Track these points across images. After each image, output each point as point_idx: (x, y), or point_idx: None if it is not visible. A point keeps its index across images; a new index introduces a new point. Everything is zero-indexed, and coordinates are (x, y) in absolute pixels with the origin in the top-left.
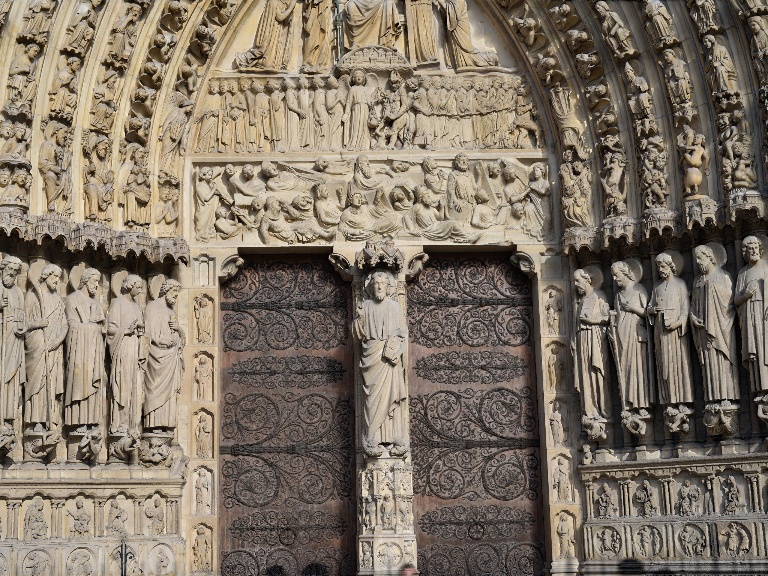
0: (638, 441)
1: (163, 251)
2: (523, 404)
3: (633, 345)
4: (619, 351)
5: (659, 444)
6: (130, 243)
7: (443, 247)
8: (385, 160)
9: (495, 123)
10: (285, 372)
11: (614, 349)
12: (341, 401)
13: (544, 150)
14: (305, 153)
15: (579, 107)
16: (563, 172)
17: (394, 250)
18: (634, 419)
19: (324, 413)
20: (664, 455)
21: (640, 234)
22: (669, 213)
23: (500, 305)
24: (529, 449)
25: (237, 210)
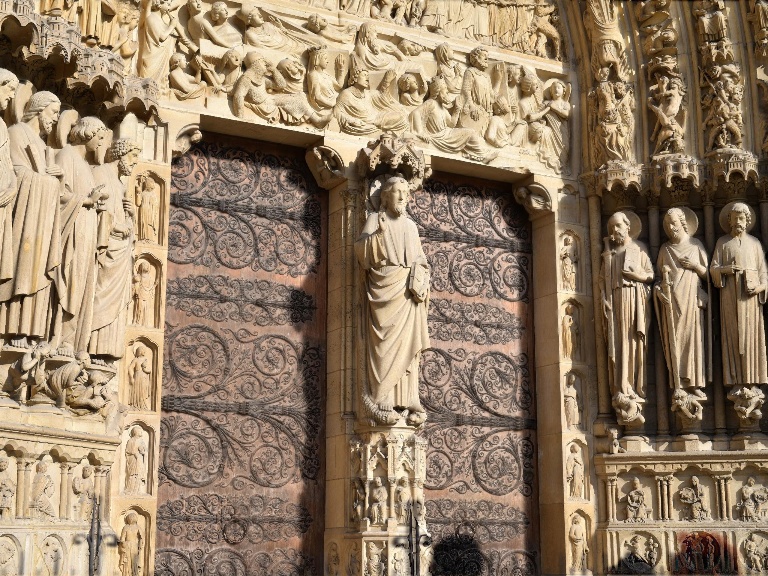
0: (675, 429)
1: (128, 93)
2: (519, 374)
3: (694, 310)
4: (675, 316)
5: (706, 433)
6: (100, 67)
7: (448, 162)
8: (391, 36)
9: (515, 19)
10: (239, 300)
11: (668, 313)
12: (309, 348)
13: (565, 64)
14: (294, 4)
15: (622, 18)
16: (605, 92)
17: (418, 151)
18: (692, 400)
19: (287, 362)
20: (718, 447)
21: (704, 178)
22: (751, 156)
23: (497, 248)
24: (524, 432)
25: (204, 62)
